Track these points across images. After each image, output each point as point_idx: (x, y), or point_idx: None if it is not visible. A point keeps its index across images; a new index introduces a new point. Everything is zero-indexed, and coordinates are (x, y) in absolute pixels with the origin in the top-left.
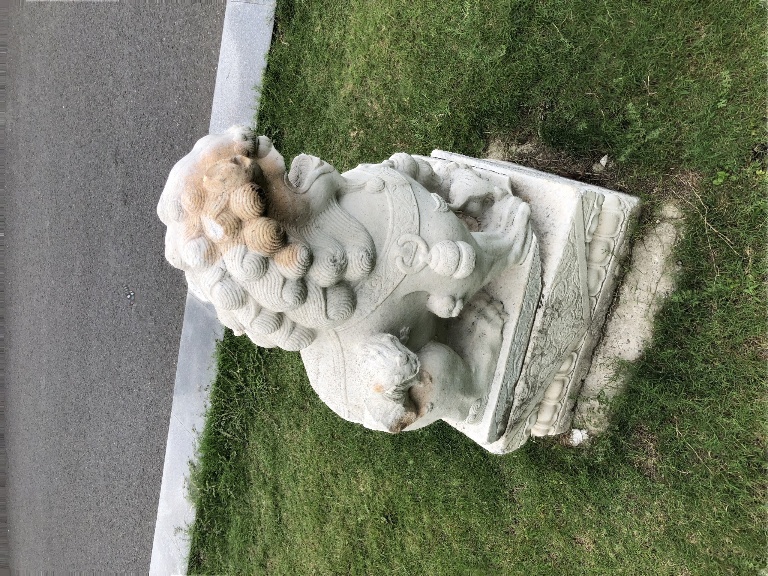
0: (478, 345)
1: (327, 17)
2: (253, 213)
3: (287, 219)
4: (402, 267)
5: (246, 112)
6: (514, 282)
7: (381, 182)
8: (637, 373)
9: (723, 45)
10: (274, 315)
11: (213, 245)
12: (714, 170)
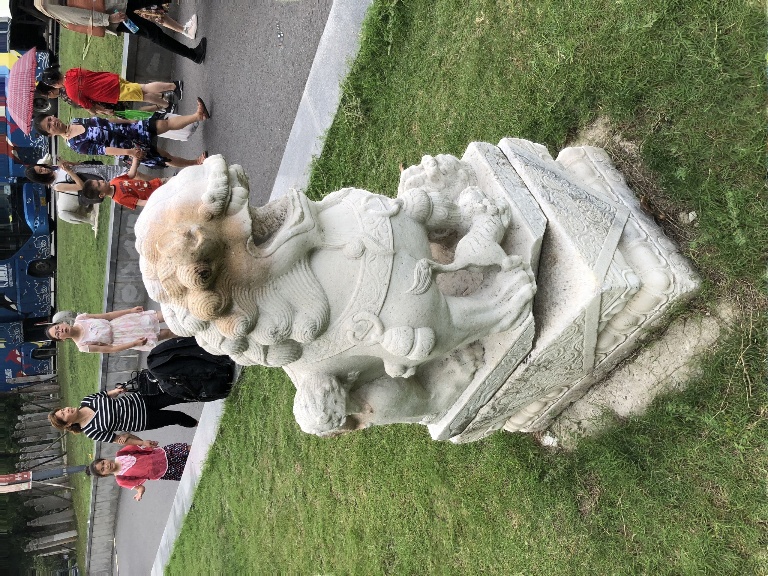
0: (444, 379)
1: None
2: (196, 288)
3: (240, 283)
4: (352, 340)
5: None
6: (500, 340)
7: (360, 249)
8: (613, 434)
9: None
10: None
11: None
12: None
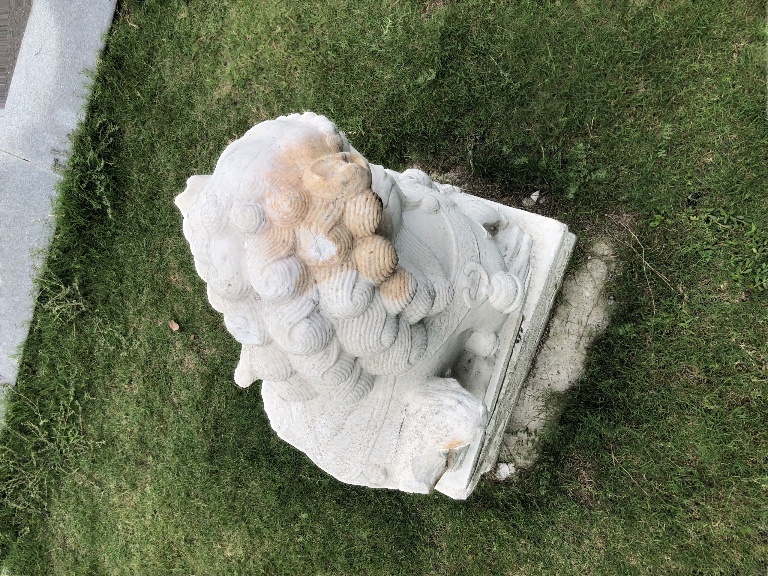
0: (475, 384)
1: (198, 4)
2: (371, 229)
3: None
4: (469, 300)
5: (68, 100)
6: None
7: (437, 201)
8: (573, 404)
9: (663, 101)
10: (353, 361)
11: (306, 269)
12: (651, 213)
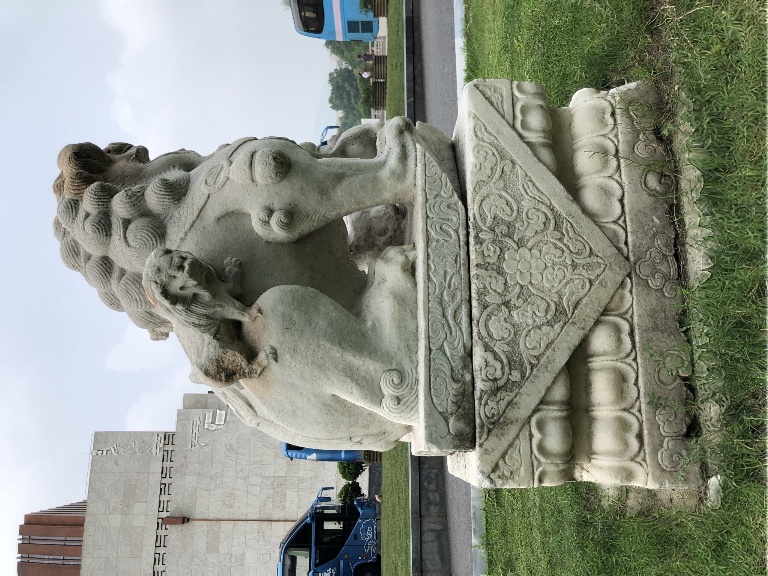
0: (376, 293)
1: None
2: (71, 170)
3: (115, 179)
4: (204, 188)
5: None
6: (417, 210)
7: None
8: None
9: None
10: (98, 259)
11: None
12: None
